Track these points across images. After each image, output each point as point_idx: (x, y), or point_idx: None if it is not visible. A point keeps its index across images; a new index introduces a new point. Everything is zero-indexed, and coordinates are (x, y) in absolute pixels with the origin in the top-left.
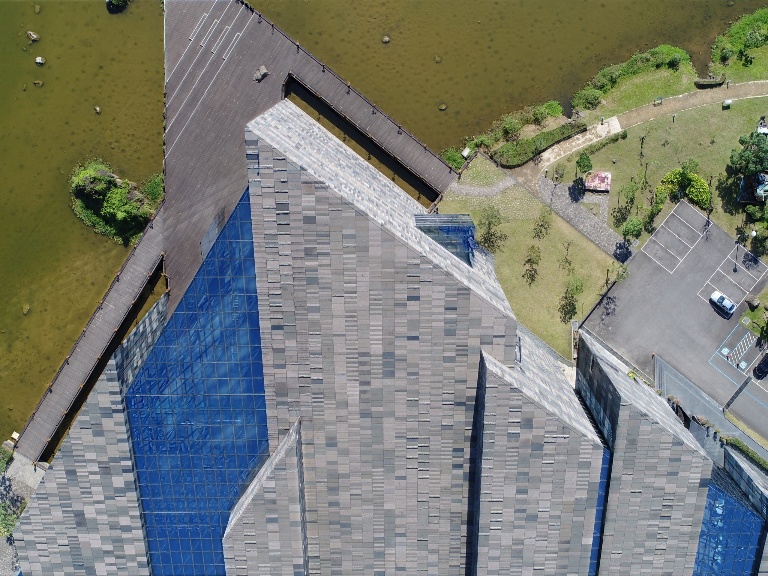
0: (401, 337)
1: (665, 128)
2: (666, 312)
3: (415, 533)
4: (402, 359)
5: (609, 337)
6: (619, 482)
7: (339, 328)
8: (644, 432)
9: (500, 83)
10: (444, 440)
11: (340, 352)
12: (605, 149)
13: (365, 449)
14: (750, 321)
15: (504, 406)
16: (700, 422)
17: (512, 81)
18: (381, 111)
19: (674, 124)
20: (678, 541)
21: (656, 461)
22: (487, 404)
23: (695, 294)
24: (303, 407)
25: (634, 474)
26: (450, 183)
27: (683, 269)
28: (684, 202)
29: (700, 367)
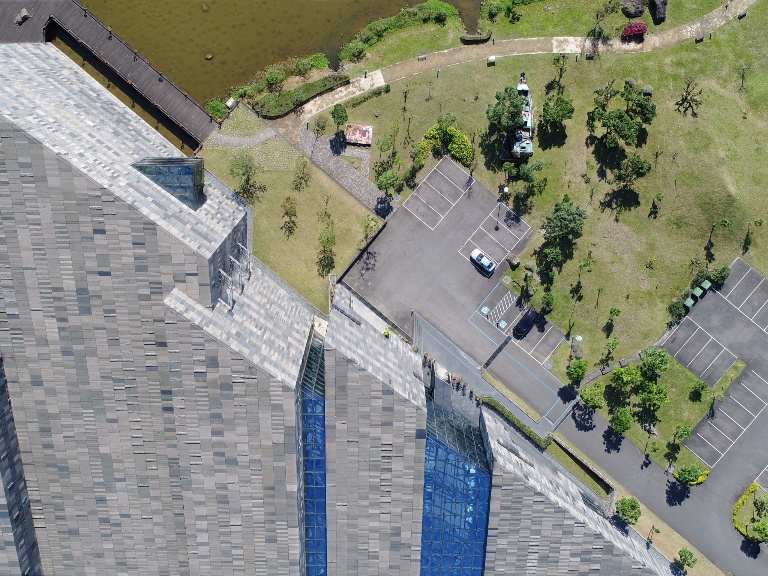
0: (93, 272)
1: (429, 83)
2: (426, 269)
3: (135, 479)
4: (97, 295)
5: (368, 293)
6: (334, 431)
7: (28, 261)
8: (352, 379)
9: (267, 34)
10: (151, 382)
11: (33, 286)
12: (368, 102)
13: (72, 389)
14: (511, 280)
15: (187, 343)
16: (455, 380)
17: (279, 32)
18: (142, 58)
19: (438, 79)
20: (402, 494)
21: (369, 410)
22: (169, 341)
23: (456, 251)
24: (3, 343)
25: (348, 423)
26: (210, 132)
27: (444, 226)
28: (447, 158)
29: (459, 325)
